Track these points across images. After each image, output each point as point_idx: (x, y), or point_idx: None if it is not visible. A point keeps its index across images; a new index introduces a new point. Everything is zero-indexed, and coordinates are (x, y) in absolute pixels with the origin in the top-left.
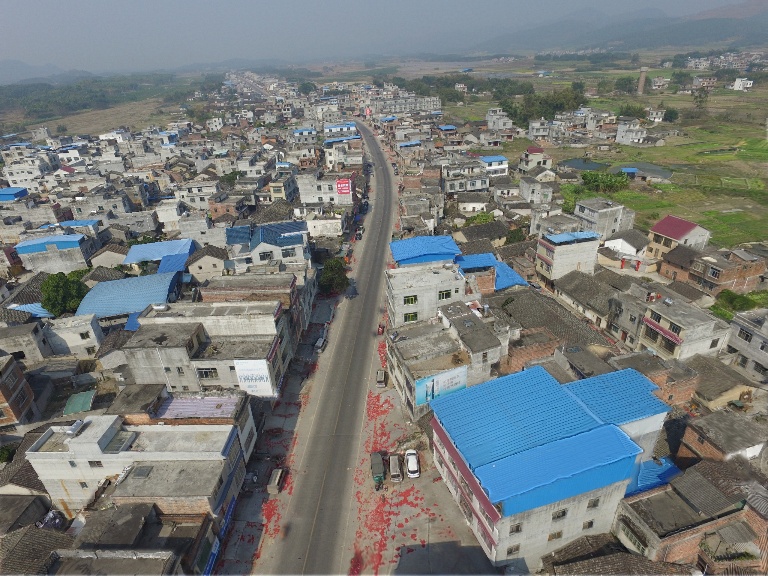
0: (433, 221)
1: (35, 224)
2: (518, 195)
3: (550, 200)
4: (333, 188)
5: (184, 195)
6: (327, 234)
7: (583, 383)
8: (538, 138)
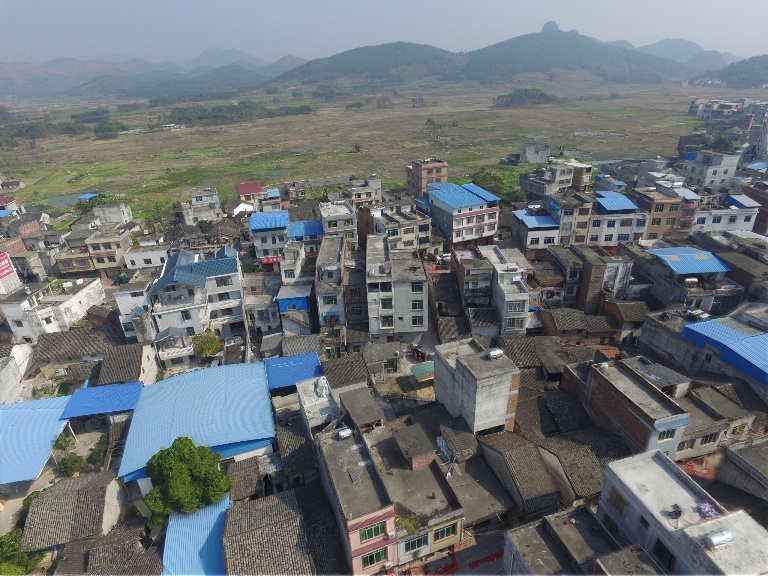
0: (162, 239)
1: None
2: (102, 224)
3: (132, 216)
4: None
5: None
6: (102, 300)
7: None
8: None
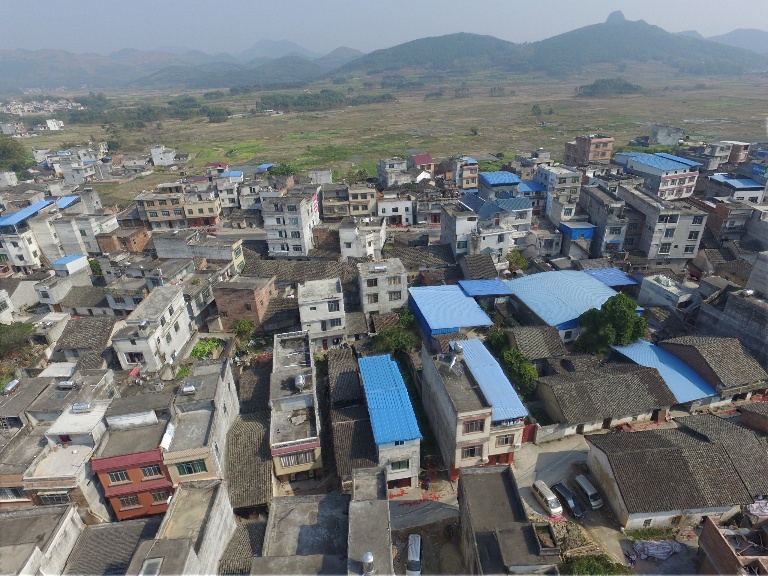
0: None
1: (267, 544)
2: None
3: None
4: (312, 209)
5: (159, 336)
6: (391, 234)
7: (634, 155)
8: (88, 179)
